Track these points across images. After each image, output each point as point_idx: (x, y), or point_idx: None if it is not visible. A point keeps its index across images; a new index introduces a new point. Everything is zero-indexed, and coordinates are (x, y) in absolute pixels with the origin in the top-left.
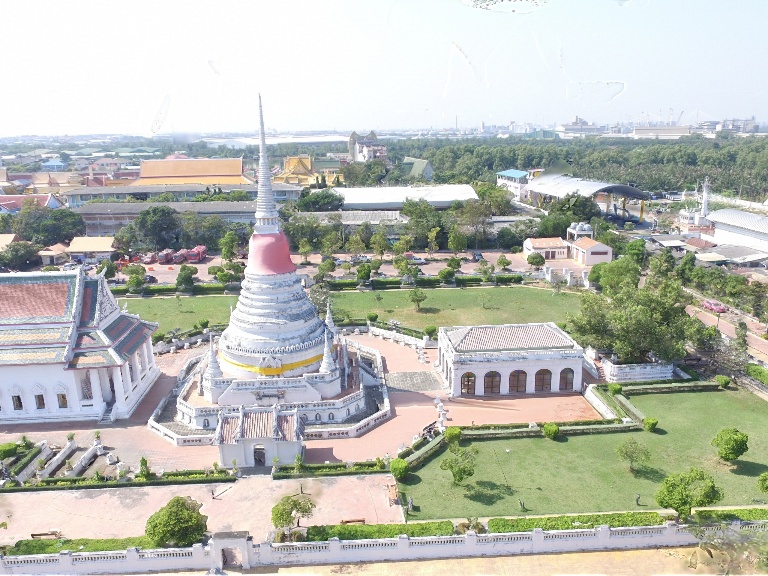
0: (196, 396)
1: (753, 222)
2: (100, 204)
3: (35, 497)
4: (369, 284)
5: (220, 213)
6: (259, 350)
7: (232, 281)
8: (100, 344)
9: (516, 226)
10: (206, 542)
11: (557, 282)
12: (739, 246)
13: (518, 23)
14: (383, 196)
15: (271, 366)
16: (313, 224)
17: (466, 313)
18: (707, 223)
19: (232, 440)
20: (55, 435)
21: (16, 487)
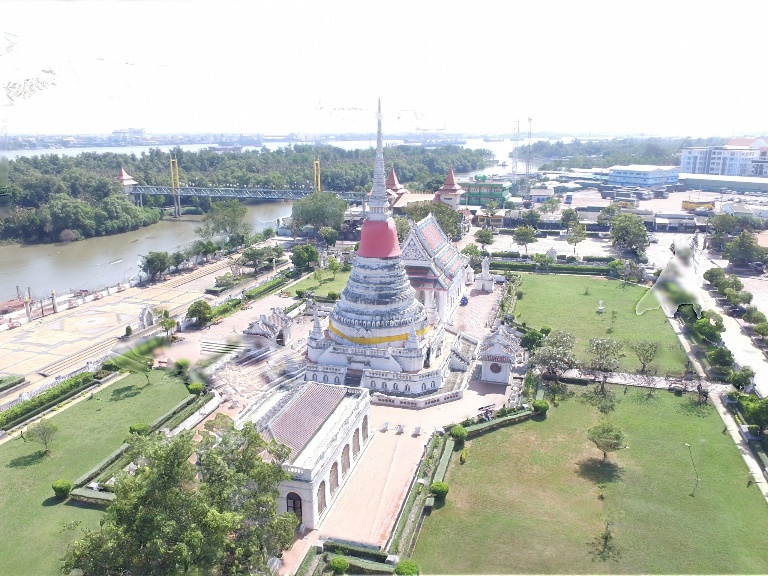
0: None
1: None
2: None
3: None
4: None
5: None
6: None
7: None
8: None
9: None
10: (198, 327)
11: None
12: None
13: (3, 89)
14: None
15: None
16: None
17: (572, 504)
18: None
19: None
20: None
21: None
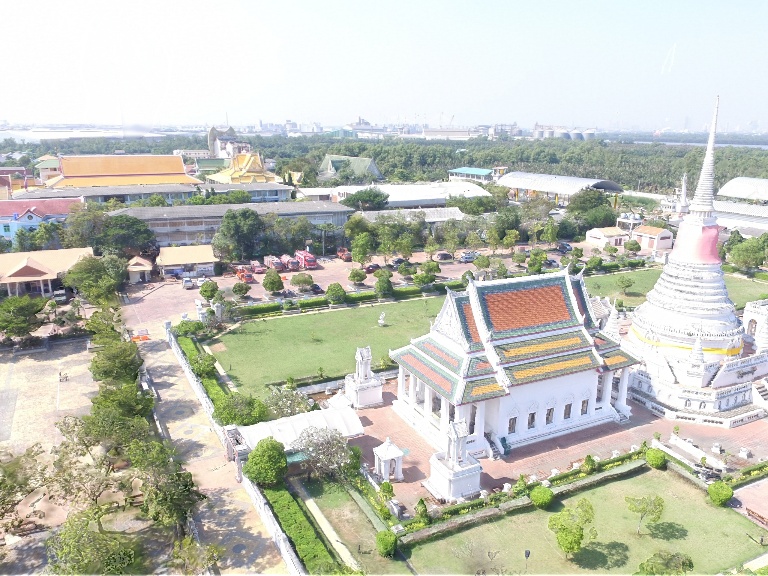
0: None
1: (744, 208)
2: (144, 208)
3: (764, 488)
4: None
5: (295, 214)
6: (726, 333)
7: (427, 283)
8: (613, 344)
9: (569, 218)
10: None
11: None
12: (751, 227)
13: None
14: (410, 194)
15: (735, 347)
16: (404, 223)
17: None
18: (687, 211)
19: None
20: (610, 441)
21: (732, 484)
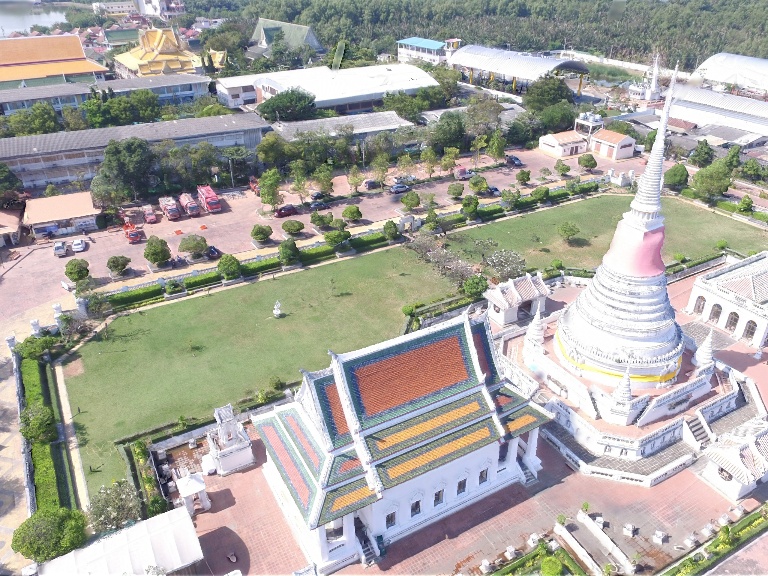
0: (594, 421)
1: (718, 100)
2: (8, 140)
3: None
4: (473, 216)
5: (197, 137)
6: (661, 358)
7: None
8: (520, 401)
9: (521, 119)
10: None
11: (626, 185)
12: (723, 126)
13: None
14: (342, 88)
15: (670, 371)
16: (327, 141)
17: None
18: (657, 98)
19: (760, 473)
20: (509, 520)
21: None
